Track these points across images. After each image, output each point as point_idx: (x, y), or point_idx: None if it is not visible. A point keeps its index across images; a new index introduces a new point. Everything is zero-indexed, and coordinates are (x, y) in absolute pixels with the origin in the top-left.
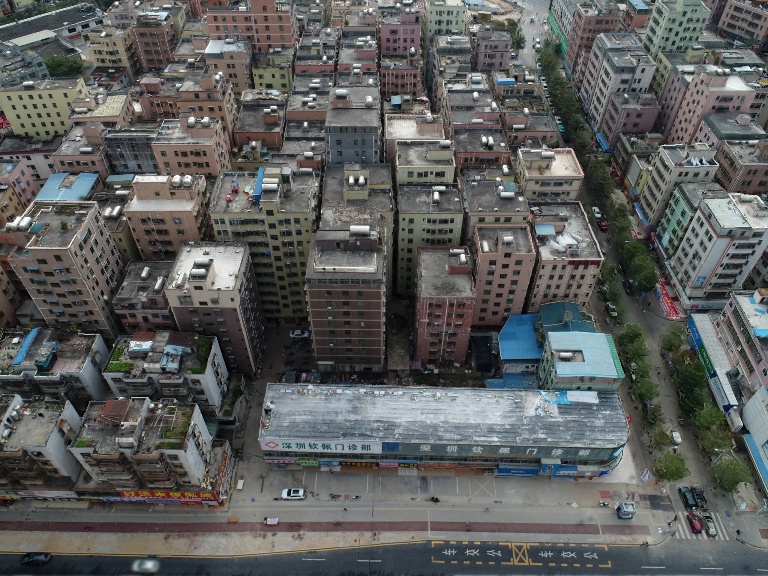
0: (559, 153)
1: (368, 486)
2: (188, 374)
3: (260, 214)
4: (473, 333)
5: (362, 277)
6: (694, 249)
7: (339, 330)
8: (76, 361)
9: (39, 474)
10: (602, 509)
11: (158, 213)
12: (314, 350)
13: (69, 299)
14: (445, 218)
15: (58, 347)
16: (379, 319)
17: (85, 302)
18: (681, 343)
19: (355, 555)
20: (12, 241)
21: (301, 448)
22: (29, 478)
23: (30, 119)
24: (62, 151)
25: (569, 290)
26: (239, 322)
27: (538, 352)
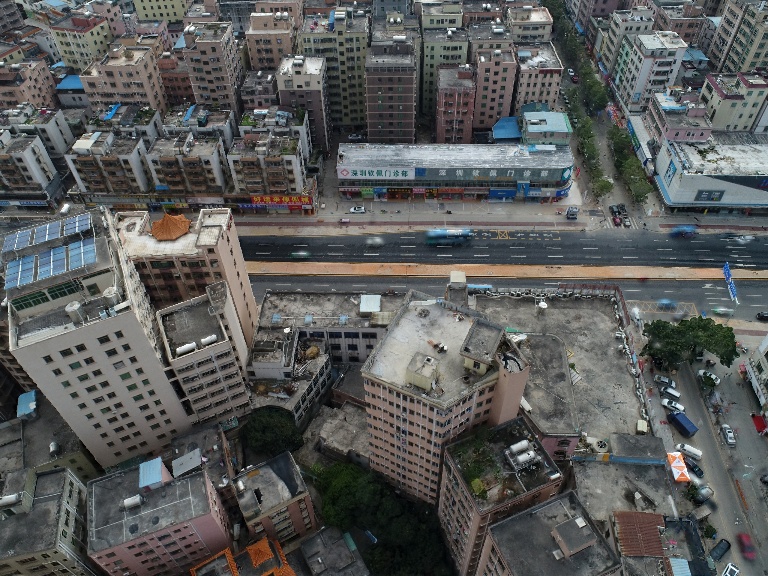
0: (537, 11)
1: (405, 207)
2: (292, 126)
3: (334, 34)
4: (476, 132)
5: (401, 66)
6: (632, 74)
7: (385, 113)
8: (220, 123)
9: (204, 181)
10: (557, 216)
11: (267, 35)
12: (368, 133)
13: (215, 85)
14: (455, 46)
15: (209, 113)
16: (412, 103)
17: (225, 87)
18: (619, 131)
19: (398, 235)
20: (165, 66)
21: (363, 175)
22: (198, 184)
23: (152, 10)
24: (189, 16)
25: (541, 97)
26: (321, 103)
27: (519, 134)
